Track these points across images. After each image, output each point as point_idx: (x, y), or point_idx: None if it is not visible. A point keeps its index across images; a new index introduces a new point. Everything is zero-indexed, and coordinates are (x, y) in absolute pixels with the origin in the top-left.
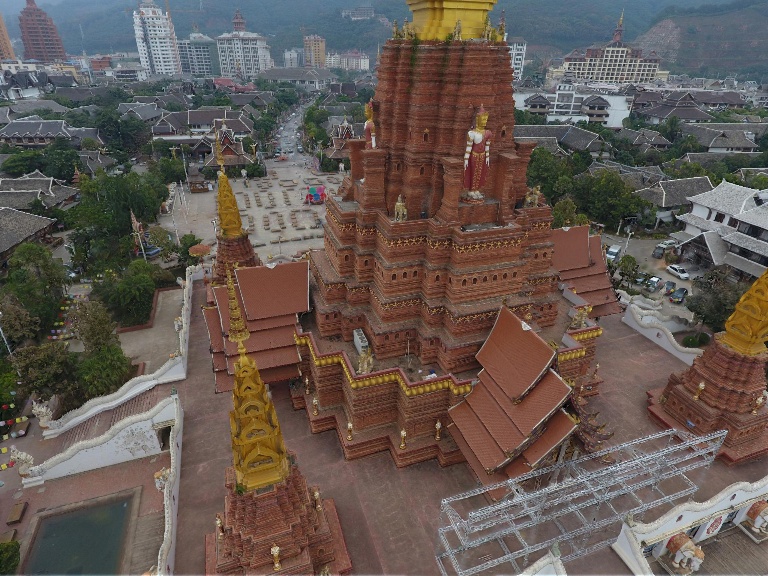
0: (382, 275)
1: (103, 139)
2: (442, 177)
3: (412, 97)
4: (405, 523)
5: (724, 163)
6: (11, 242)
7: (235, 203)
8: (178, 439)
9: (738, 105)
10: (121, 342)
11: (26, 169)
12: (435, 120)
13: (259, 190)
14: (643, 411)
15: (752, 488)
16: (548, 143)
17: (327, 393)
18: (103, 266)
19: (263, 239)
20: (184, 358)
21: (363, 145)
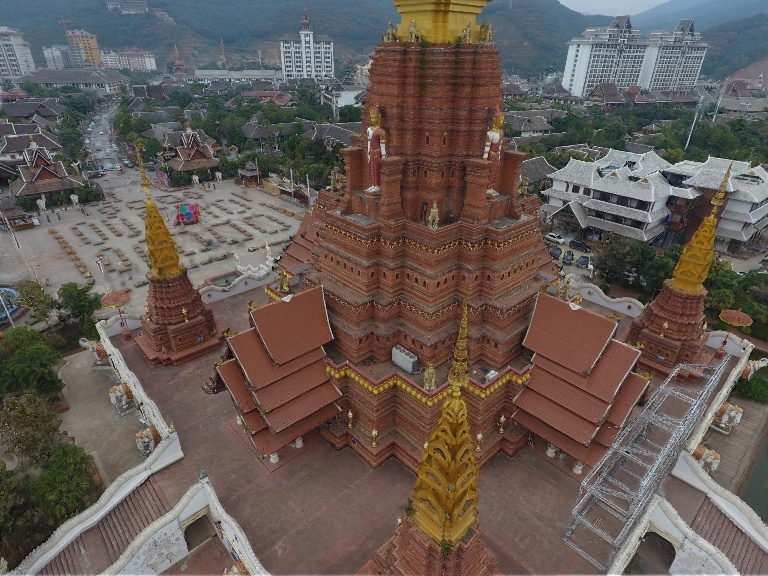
0: (424, 285)
1: None
2: (462, 179)
3: (426, 101)
4: (517, 520)
5: (544, 144)
6: None
7: None
8: None
9: (519, 95)
10: None
11: None
12: (451, 123)
13: (106, 217)
14: None
15: None
16: None
17: (381, 421)
18: None
19: None
20: None
21: (360, 153)
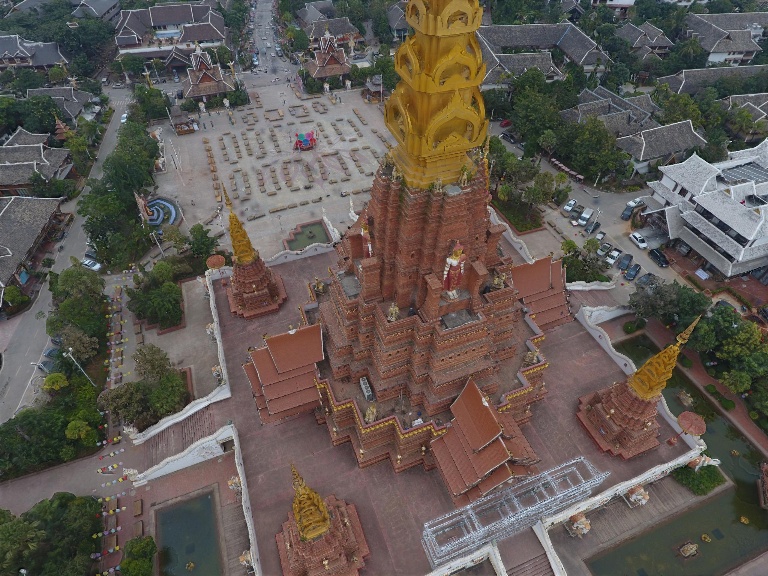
0: None
1: (65, 56)
2: (426, 282)
3: (401, 225)
4: (402, 516)
5: (715, 90)
6: (33, 236)
7: (245, 235)
8: (240, 460)
9: None
10: (164, 345)
11: (5, 121)
12: (420, 244)
13: (246, 128)
14: (574, 414)
15: (631, 483)
16: (542, 60)
17: (343, 421)
18: (124, 258)
19: (261, 206)
20: (227, 380)
21: (360, 236)
